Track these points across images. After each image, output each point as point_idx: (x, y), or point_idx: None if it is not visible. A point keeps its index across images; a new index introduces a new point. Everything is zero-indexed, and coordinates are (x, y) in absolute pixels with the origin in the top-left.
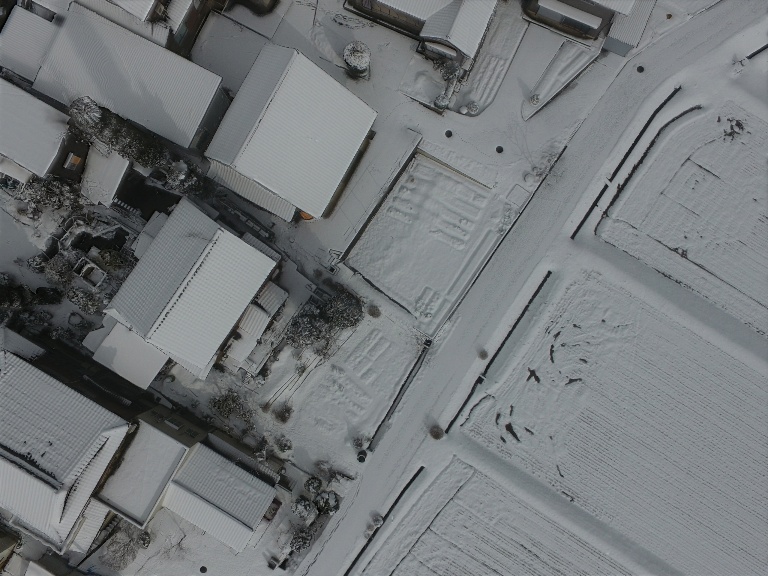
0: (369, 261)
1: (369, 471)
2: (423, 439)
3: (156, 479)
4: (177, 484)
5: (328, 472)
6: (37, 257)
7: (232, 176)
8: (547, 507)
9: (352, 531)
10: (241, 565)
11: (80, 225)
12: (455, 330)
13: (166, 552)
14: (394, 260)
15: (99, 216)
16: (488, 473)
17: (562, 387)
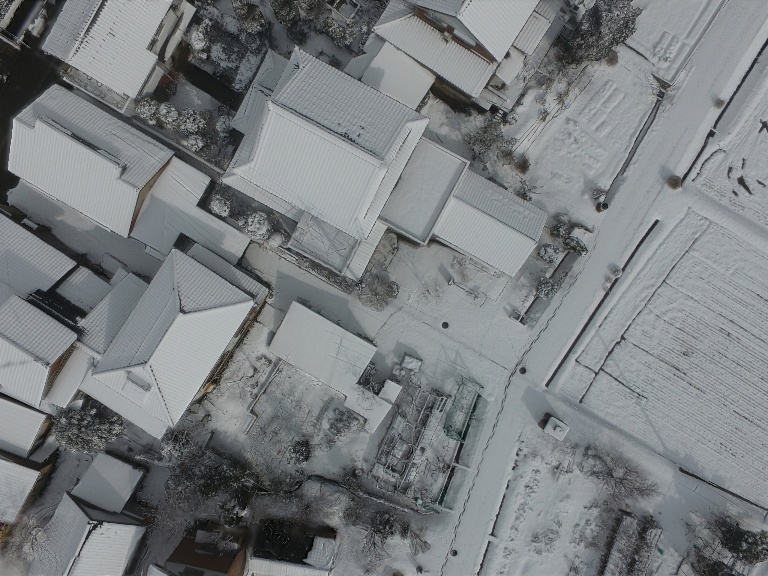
0: None
1: (606, 224)
2: (659, 191)
3: (434, 197)
4: (458, 199)
5: (568, 223)
6: None
7: None
8: None
9: (590, 285)
10: (482, 320)
11: None
12: (689, 80)
13: (423, 293)
14: (631, 4)
15: None
16: (724, 223)
17: None
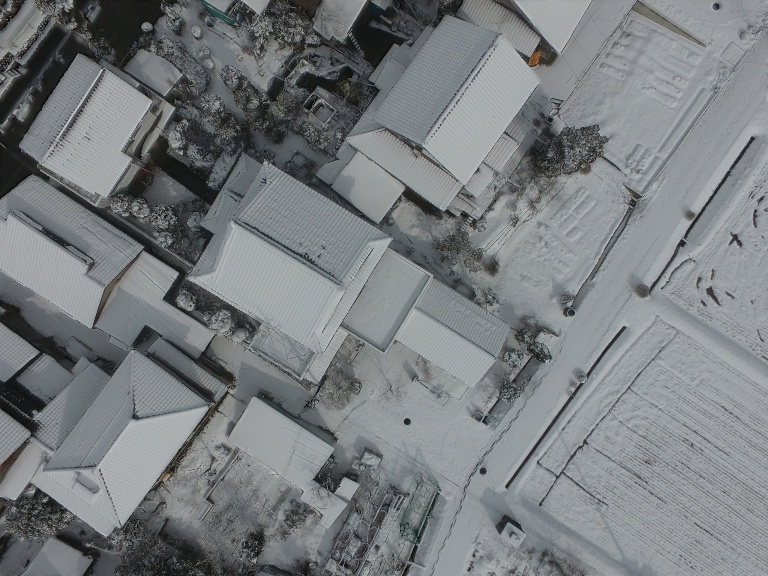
0: (580, 117)
1: (572, 329)
2: (627, 298)
3: (397, 307)
4: (420, 311)
5: (534, 327)
6: (264, 94)
7: (481, 4)
8: (751, 368)
9: (555, 388)
10: (444, 418)
11: (304, 65)
12: (661, 191)
13: (384, 394)
14: (606, 116)
15: (322, 57)
16: (691, 334)
17: (764, 252)
